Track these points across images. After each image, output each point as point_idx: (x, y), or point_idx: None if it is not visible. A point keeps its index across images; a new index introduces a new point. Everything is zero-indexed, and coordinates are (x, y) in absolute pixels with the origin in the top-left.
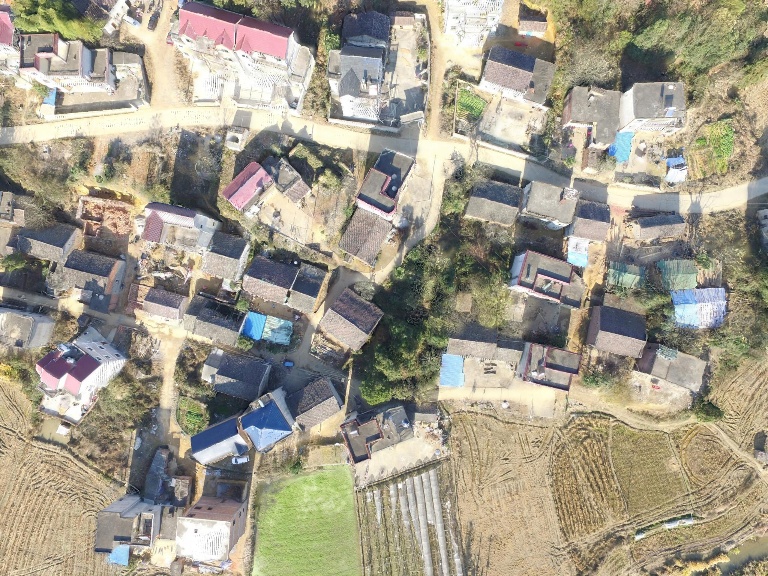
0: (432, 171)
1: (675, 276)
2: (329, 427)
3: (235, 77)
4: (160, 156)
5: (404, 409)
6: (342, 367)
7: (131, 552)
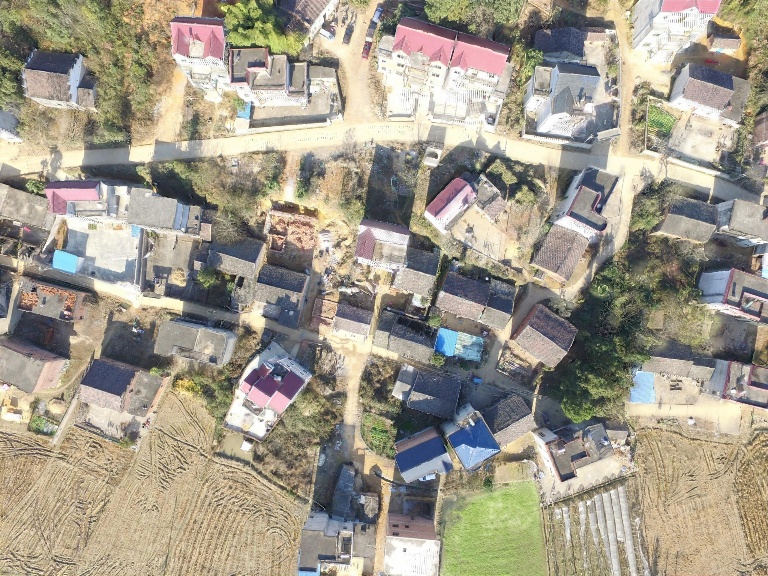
0: (621, 187)
1: None
2: (515, 443)
3: (430, 92)
4: (355, 171)
5: (603, 427)
6: (532, 384)
7: (320, 570)
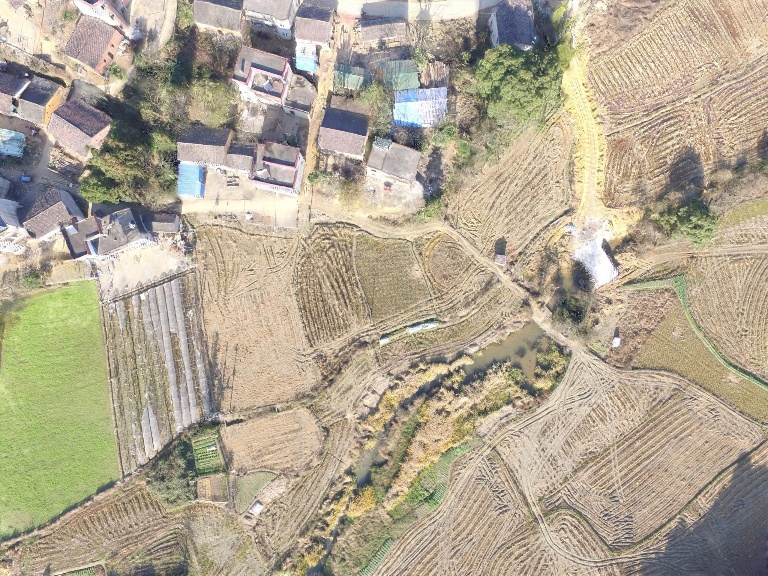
0: None
1: (397, 75)
2: None
3: None
4: None
5: (131, 211)
6: (78, 179)
7: None
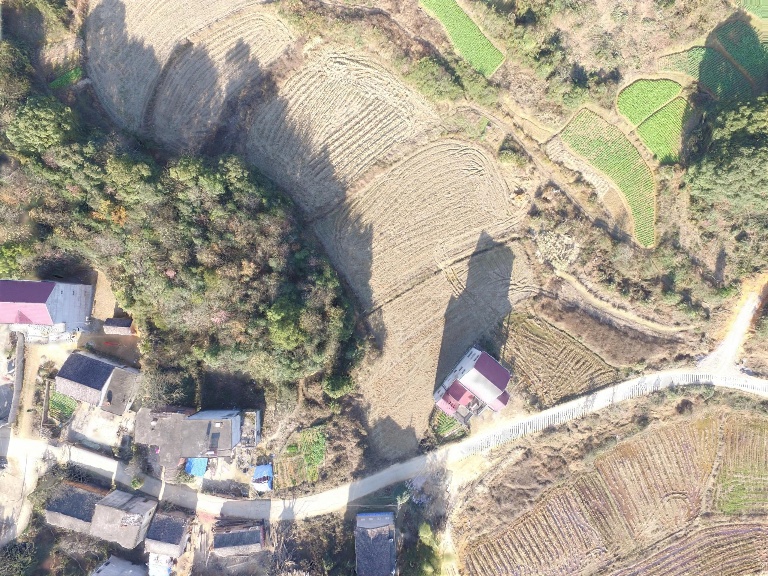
0: (24, 469)
1: None
2: None
3: None
4: None
5: None
6: None
7: None
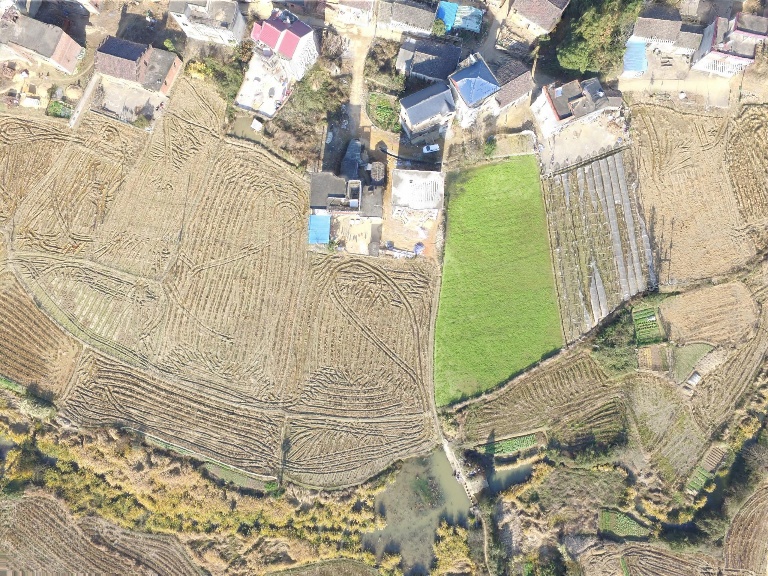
0: None
1: None
2: (514, 119)
3: None
4: None
5: (598, 80)
6: None
7: None
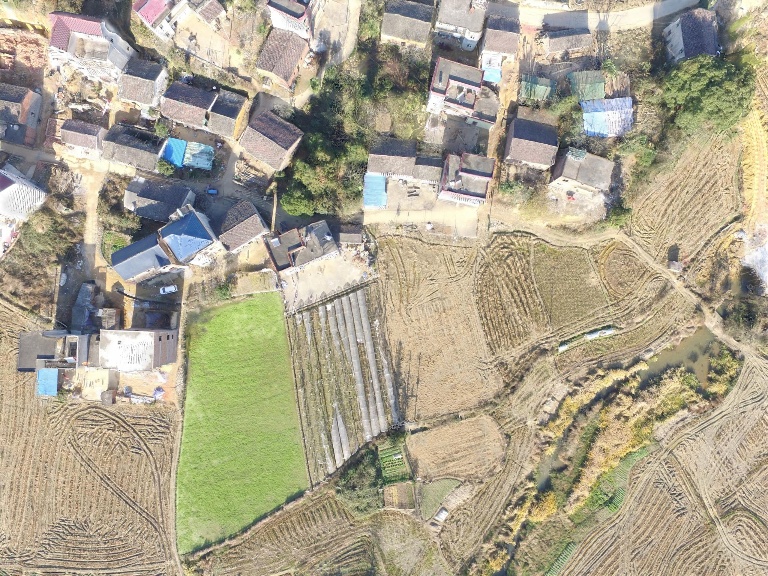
0: None
1: (584, 86)
2: (257, 255)
3: None
4: None
5: (326, 223)
6: (266, 191)
7: (60, 384)
